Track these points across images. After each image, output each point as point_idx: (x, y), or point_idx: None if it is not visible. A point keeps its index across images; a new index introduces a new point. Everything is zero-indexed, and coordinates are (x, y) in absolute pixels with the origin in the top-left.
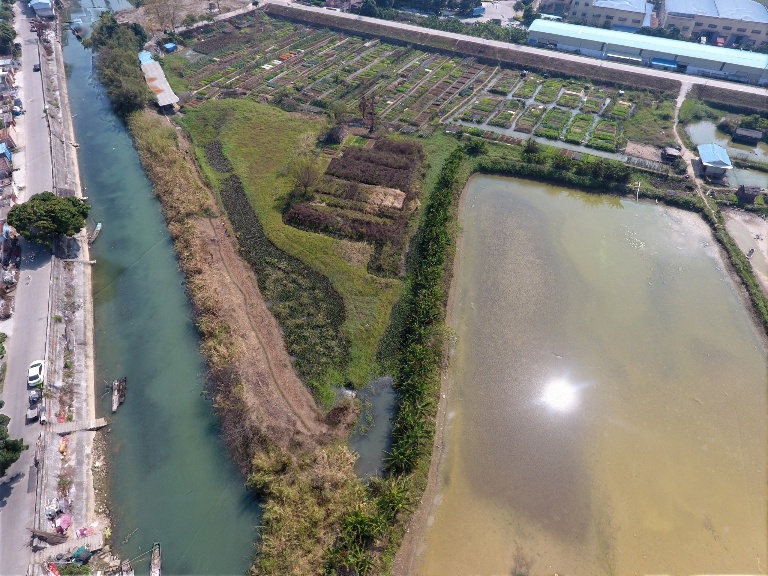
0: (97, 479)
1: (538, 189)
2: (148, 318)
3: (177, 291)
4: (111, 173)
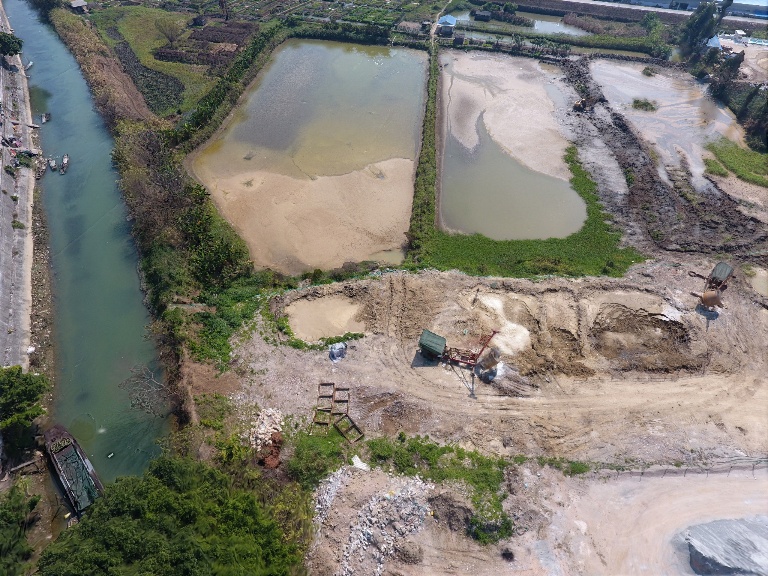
0: (34, 140)
1: (331, 44)
2: (63, 95)
3: (82, 86)
4: (38, 42)
